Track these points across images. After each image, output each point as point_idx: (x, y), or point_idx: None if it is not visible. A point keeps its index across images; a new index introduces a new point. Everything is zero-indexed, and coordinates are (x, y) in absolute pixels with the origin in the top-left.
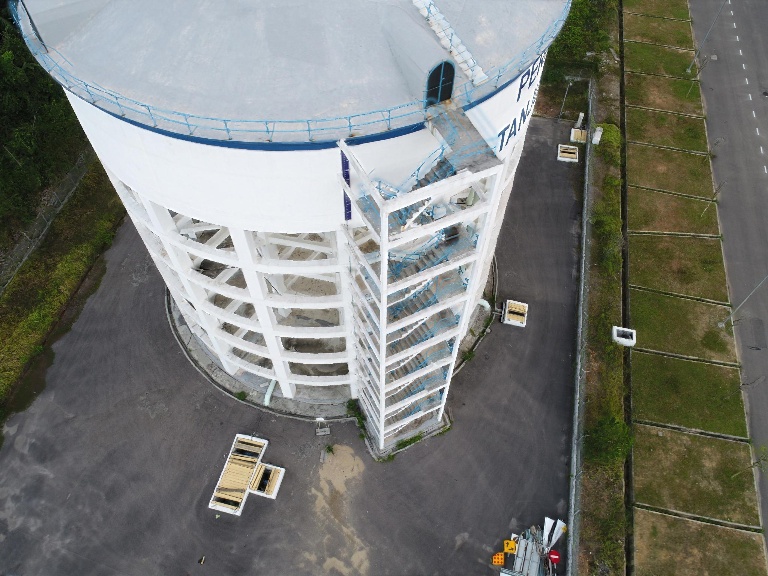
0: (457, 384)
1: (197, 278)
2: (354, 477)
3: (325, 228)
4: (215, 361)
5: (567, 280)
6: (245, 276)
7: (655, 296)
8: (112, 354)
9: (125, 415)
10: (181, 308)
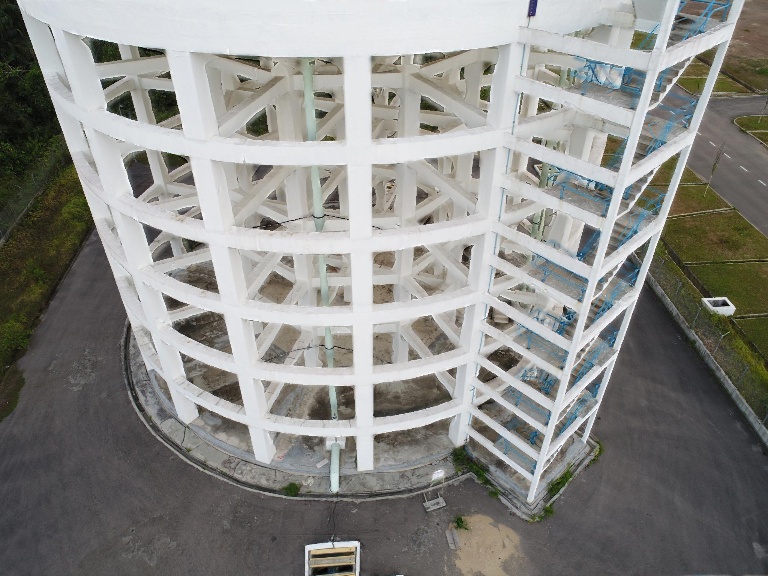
0: None
1: (250, 234)
2: (512, 555)
3: (498, 36)
4: (235, 451)
5: (623, 269)
6: (349, 184)
7: (717, 266)
8: (58, 488)
9: (102, 575)
10: (173, 375)
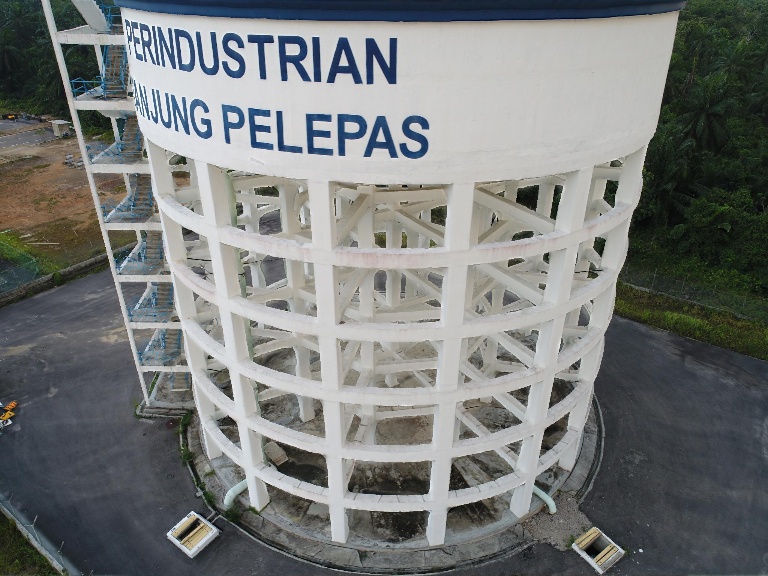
0: (169, 437)
1: None
2: None
3: None
4: None
5: None
6: None
7: None
8: None
9: None
10: None
